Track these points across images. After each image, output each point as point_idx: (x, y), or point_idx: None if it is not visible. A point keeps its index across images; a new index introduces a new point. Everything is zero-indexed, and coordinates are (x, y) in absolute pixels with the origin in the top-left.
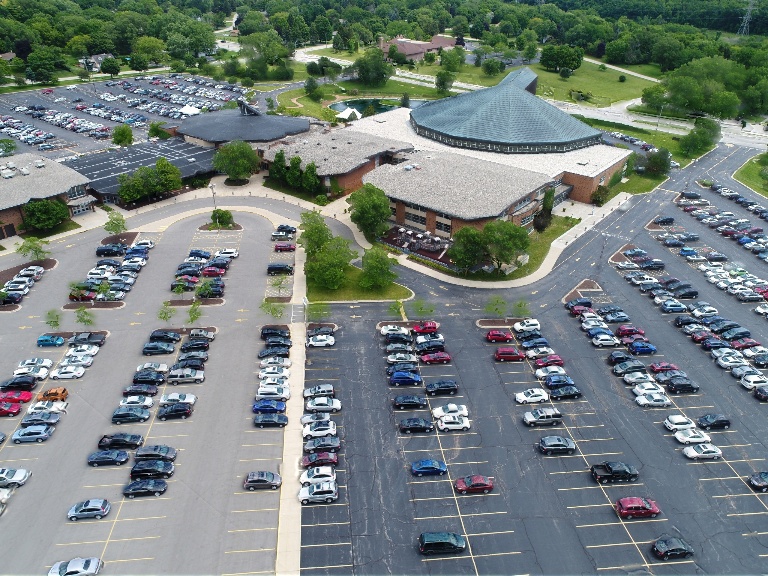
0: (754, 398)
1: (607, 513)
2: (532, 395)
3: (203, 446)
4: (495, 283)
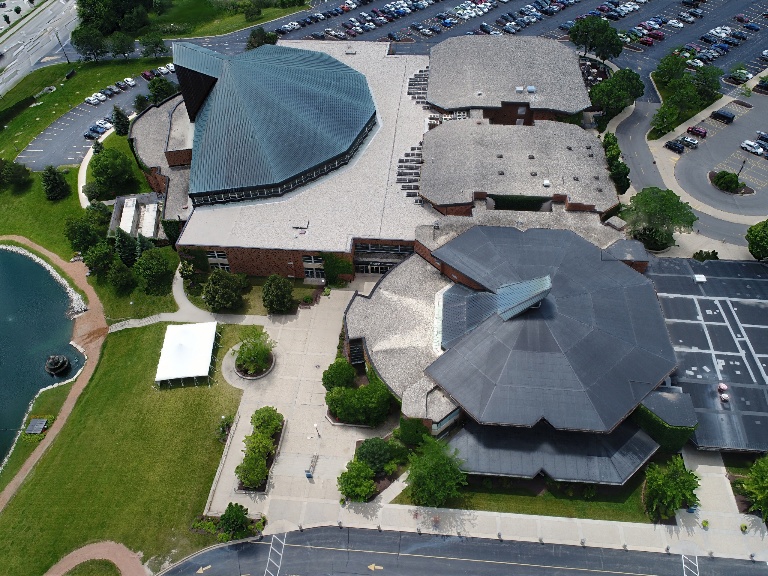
0: None
1: (708, 2)
2: None
3: None
4: (593, 57)
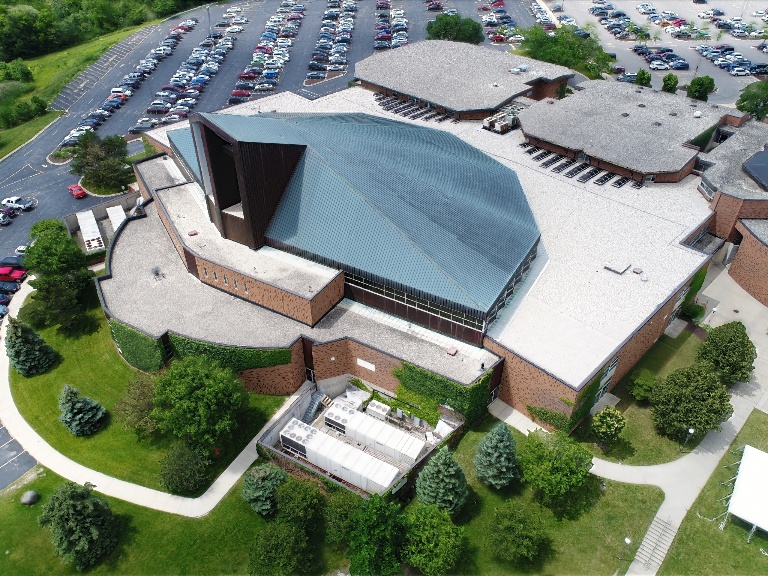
0: None
1: (443, 6)
2: None
3: (586, 16)
4: None
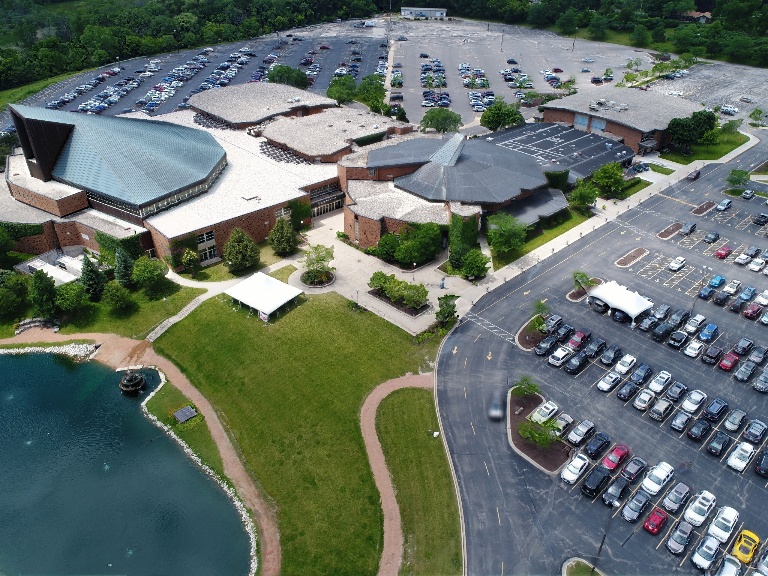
0: (239, 71)
1: None
2: (312, 71)
3: None
4: None
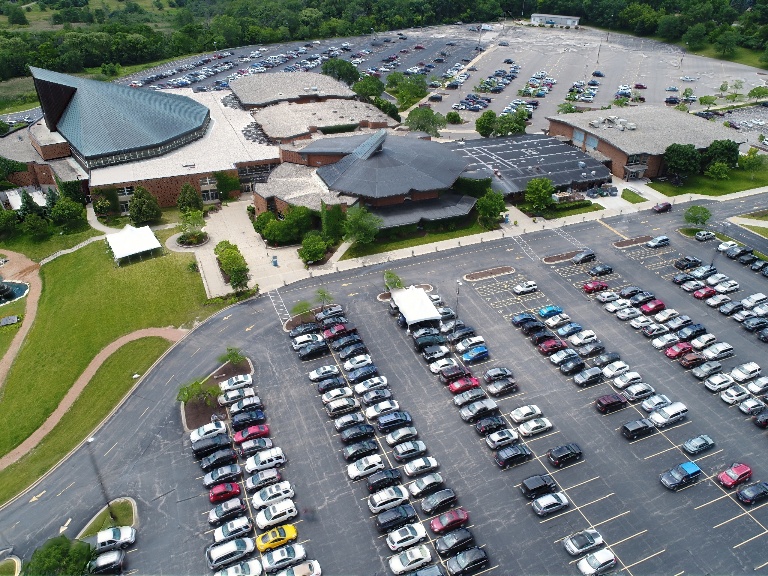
0: None
1: None
2: None
3: (486, 75)
4: None
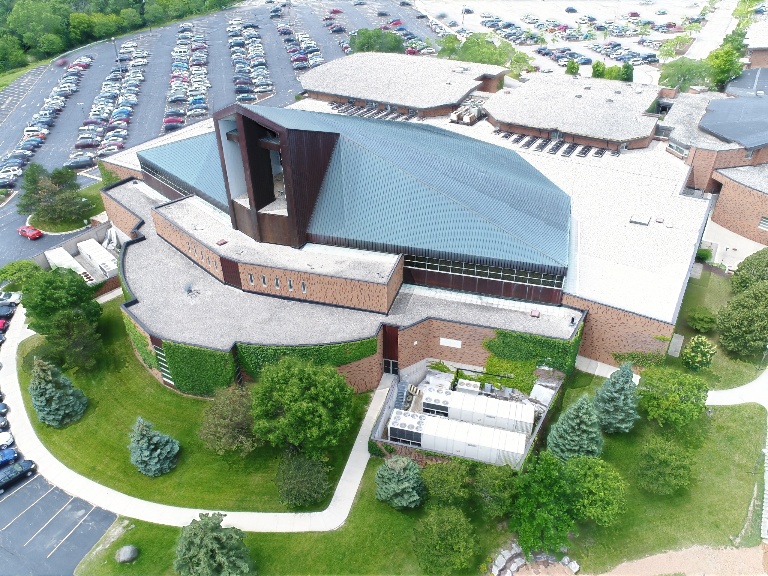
0: None
1: None
2: None
3: None
4: None
